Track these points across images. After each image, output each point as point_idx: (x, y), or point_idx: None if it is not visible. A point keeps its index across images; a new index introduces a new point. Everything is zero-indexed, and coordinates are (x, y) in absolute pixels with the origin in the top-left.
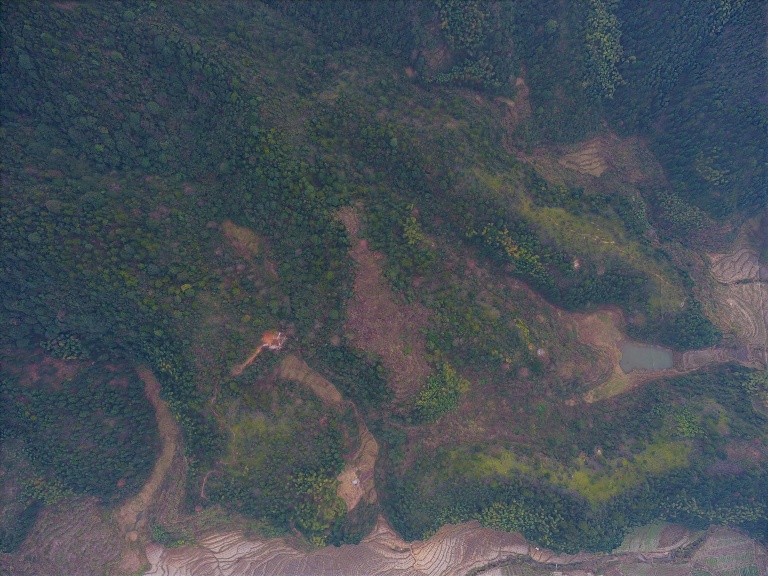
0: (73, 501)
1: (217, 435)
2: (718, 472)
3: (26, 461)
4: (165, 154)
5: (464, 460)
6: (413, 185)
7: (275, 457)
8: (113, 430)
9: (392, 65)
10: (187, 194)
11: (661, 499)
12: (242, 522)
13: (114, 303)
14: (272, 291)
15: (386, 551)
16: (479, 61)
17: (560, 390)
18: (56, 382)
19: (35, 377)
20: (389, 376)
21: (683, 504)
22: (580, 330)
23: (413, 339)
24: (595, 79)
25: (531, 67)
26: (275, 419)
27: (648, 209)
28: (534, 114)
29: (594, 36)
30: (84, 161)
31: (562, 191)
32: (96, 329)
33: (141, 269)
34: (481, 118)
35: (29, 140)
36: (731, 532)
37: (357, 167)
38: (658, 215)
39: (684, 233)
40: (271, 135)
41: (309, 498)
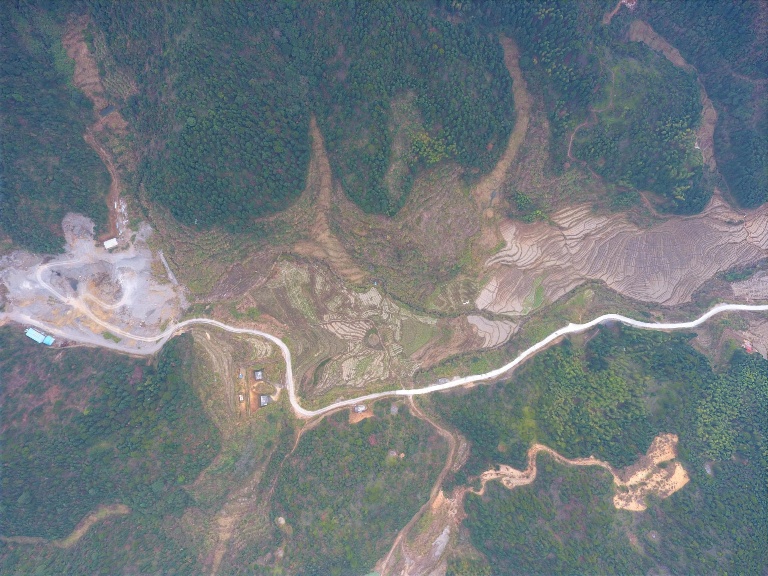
0: (443, 170)
1: (598, 76)
2: None
3: (412, 118)
4: None
5: None
6: None
7: (653, 95)
8: (491, 84)
9: None
10: None
11: None
12: (595, 191)
13: None
14: None
15: (720, 225)
16: None
17: None
18: None
19: None
20: (759, 9)
21: None
22: None
23: None
24: None
25: None
26: (647, 62)
27: None
28: None
29: None
30: None
31: None
32: None
33: None
34: None
35: None
36: None
37: None
38: None
39: None
40: None
41: None
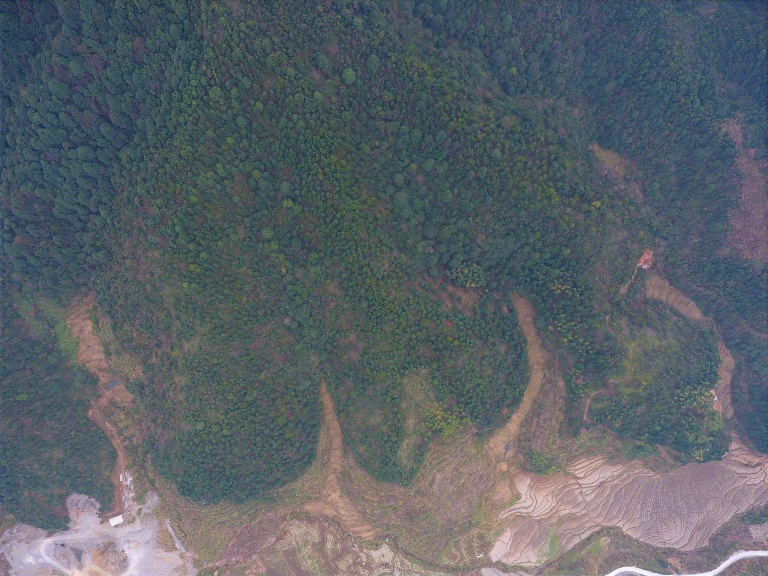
0: (456, 433)
1: (615, 352)
2: None
3: (425, 392)
4: (560, 76)
5: None
6: (760, 100)
7: (672, 370)
8: (506, 356)
9: None
10: (573, 117)
11: None
12: (611, 445)
13: (532, 223)
14: None
15: (738, 467)
16: None
17: None
18: (465, 309)
19: (449, 304)
20: None
21: None
22: None
23: None
24: None
25: None
26: (665, 334)
27: None
28: None
29: None
30: (496, 86)
31: None
32: (500, 254)
33: (558, 188)
34: None
35: None
36: None
37: (722, 82)
38: None
39: None
40: None
41: None
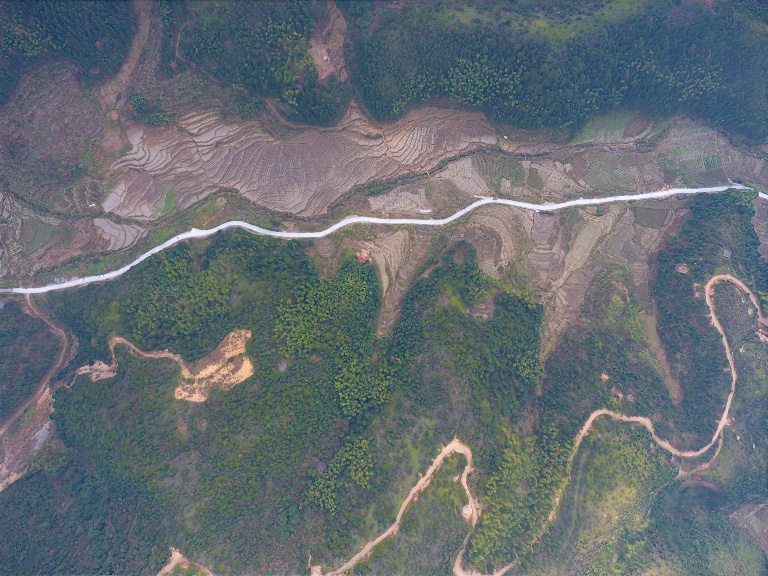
0: (54, 67)
1: None
2: (674, 21)
3: (5, 9)
4: None
5: (428, 12)
6: None
7: None
8: None
9: None
10: None
11: (620, 54)
12: (218, 96)
13: None
14: None
15: (359, 139)
16: None
17: None
18: None
19: None
20: None
21: (642, 64)
22: None
23: None
24: None
25: None
26: None
27: None
28: None
29: None
30: None
31: None
32: None
33: None
34: None
35: None
36: (693, 124)
37: None
38: None
39: None
40: None
41: None
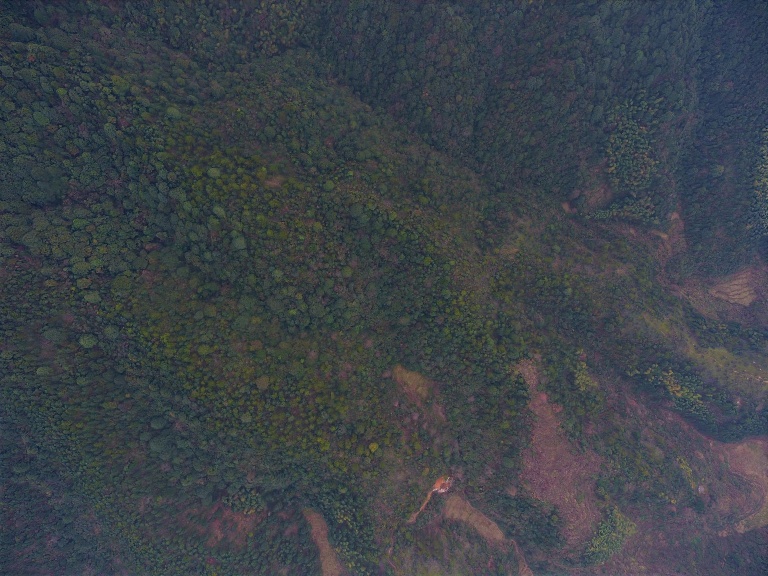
0: None
1: None
2: None
3: None
4: (350, 311)
5: None
6: (576, 325)
7: None
8: None
9: (554, 204)
10: (366, 347)
11: None
12: None
13: (304, 465)
14: (445, 438)
15: None
16: (641, 201)
17: (715, 523)
18: (238, 538)
19: (219, 535)
20: (566, 527)
21: None
22: (731, 460)
23: (584, 485)
24: (758, 221)
25: (689, 204)
26: (450, 568)
27: None
28: (690, 249)
29: (762, 183)
30: (276, 324)
31: (721, 328)
32: None
33: (332, 431)
34: (641, 256)
35: (234, 314)
36: None
37: (529, 314)
38: None
39: None
40: (462, 297)
41: None
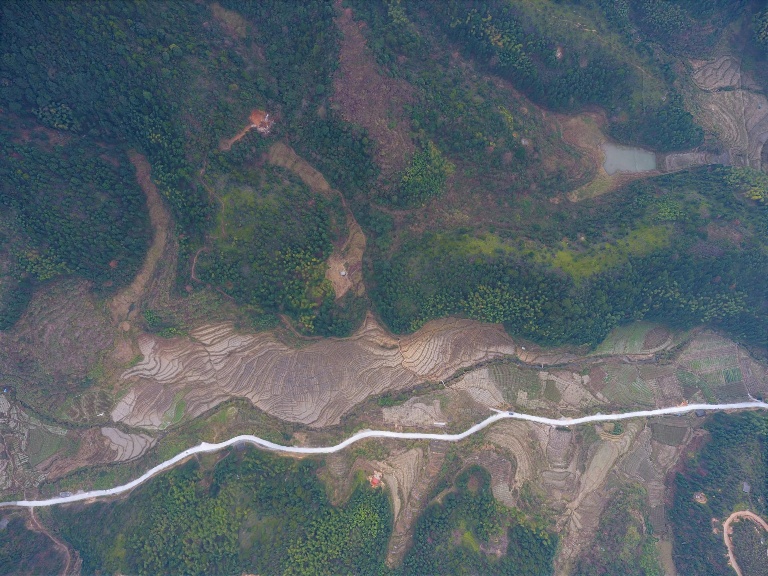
0: (66, 284)
1: (206, 205)
2: (699, 254)
3: (19, 234)
4: None
5: (449, 241)
6: None
7: (263, 227)
8: (104, 204)
9: None
10: None
11: (643, 283)
12: (232, 311)
13: (104, 60)
14: (259, 68)
15: (375, 348)
16: None
17: (544, 185)
18: (48, 147)
19: (27, 140)
20: (374, 146)
21: (665, 291)
22: (564, 131)
23: (398, 117)
24: None
25: None
26: (263, 192)
27: (631, 15)
28: None
29: None
30: None
31: None
32: (87, 95)
33: (130, 26)
34: None
35: None
36: (714, 336)
37: None
38: (640, 19)
39: (666, 37)
40: None
41: (297, 277)
